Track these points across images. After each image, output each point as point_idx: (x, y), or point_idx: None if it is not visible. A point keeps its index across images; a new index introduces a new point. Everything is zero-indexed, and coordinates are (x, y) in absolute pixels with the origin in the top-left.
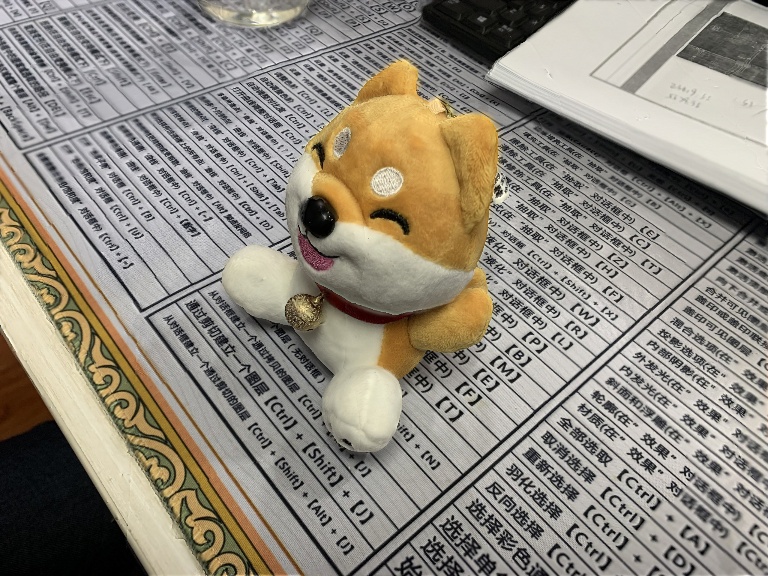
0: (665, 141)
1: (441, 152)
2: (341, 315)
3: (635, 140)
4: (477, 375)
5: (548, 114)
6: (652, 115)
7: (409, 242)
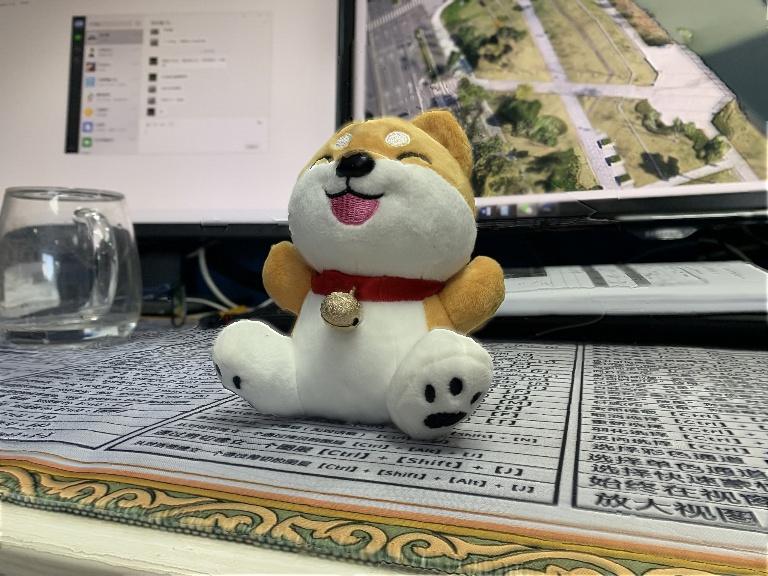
0: None
1: (422, 131)
2: (378, 304)
3: None
4: (498, 408)
5: None
6: None
7: (435, 169)
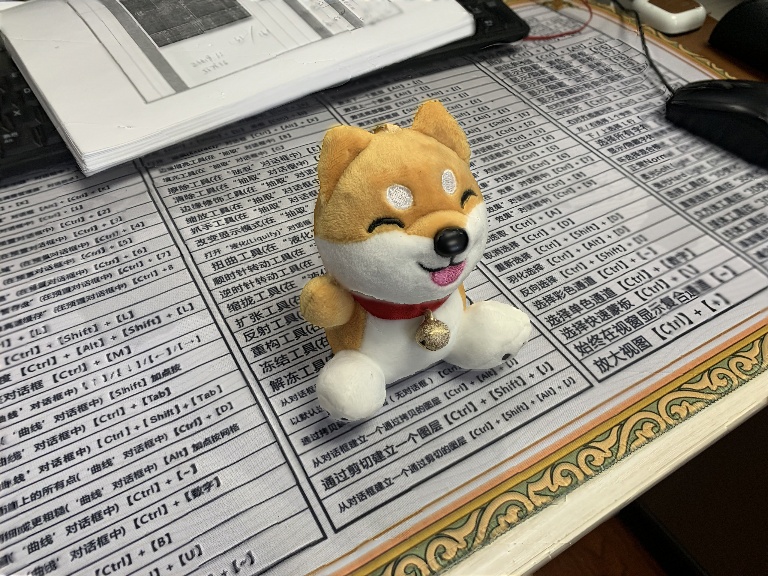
0: (255, 95)
1: None
2: (442, 309)
3: (239, 111)
4: None
5: (144, 158)
6: (221, 89)
7: (480, 199)
